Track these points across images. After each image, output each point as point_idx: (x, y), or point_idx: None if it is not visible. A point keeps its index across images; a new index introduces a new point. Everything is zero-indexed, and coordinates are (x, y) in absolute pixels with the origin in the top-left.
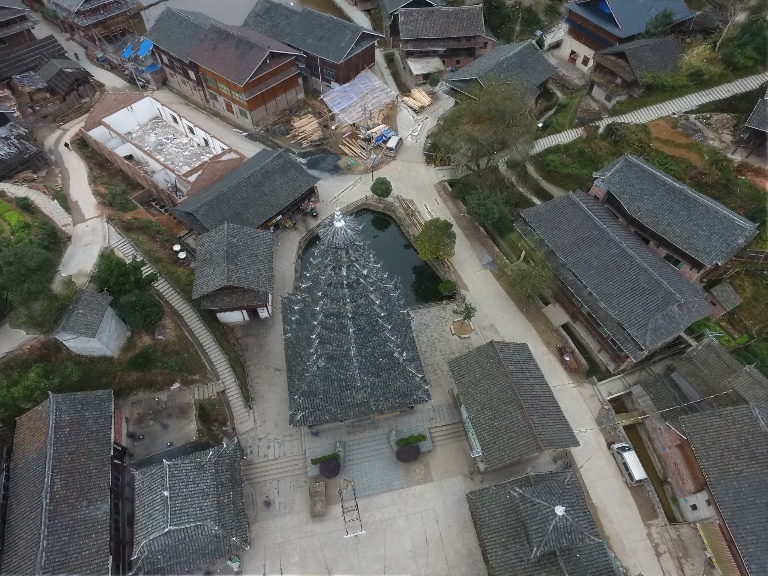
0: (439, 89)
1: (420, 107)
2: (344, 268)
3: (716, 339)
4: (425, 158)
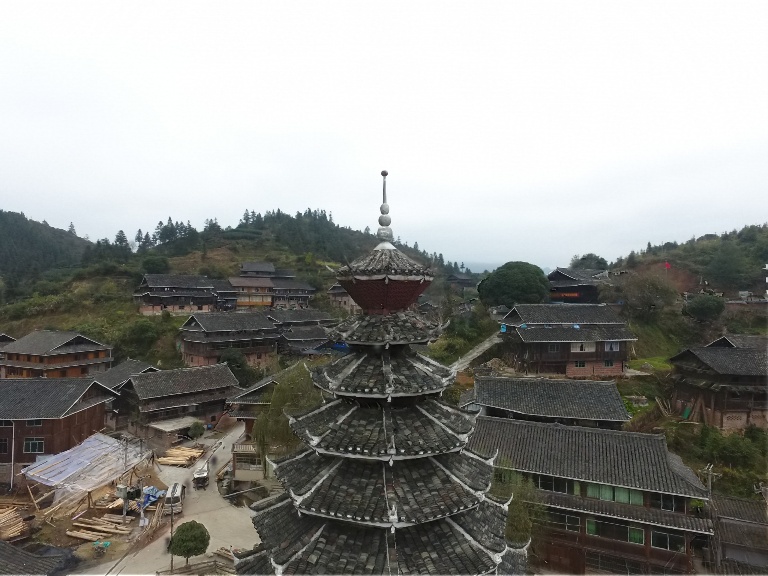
0: (224, 413)
1: (189, 459)
2: (418, 362)
3: (715, 473)
4: (229, 501)
